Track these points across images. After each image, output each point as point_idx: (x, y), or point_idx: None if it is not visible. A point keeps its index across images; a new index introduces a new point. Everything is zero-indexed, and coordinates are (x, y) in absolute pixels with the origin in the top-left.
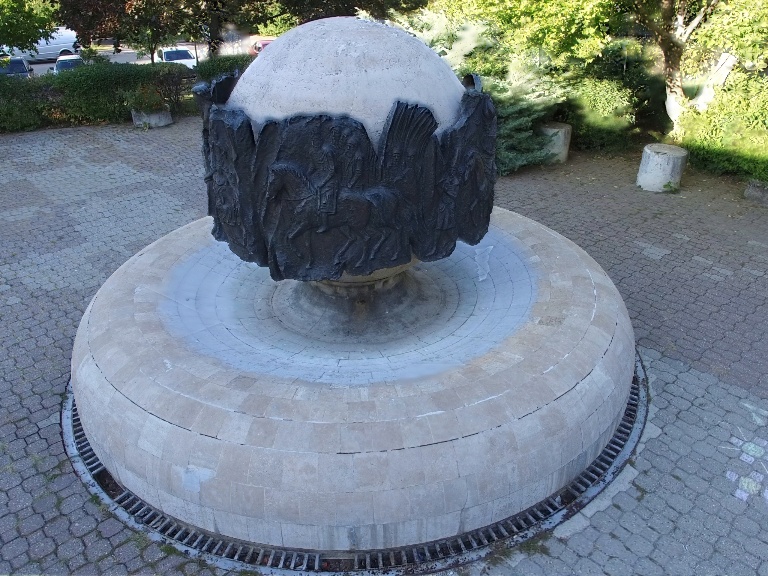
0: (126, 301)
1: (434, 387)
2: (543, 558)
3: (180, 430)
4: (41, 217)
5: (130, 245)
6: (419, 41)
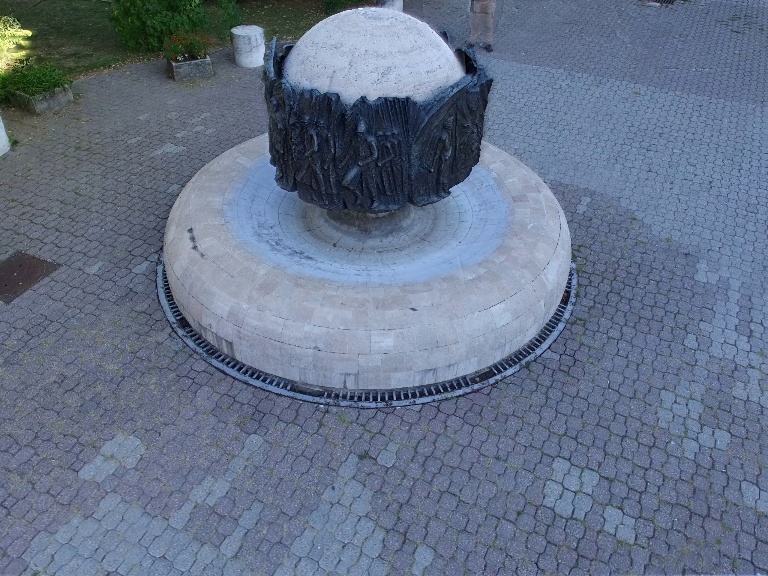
0: (489, 275)
1: None
2: None
3: (560, 213)
4: None
5: (218, 536)
6: None
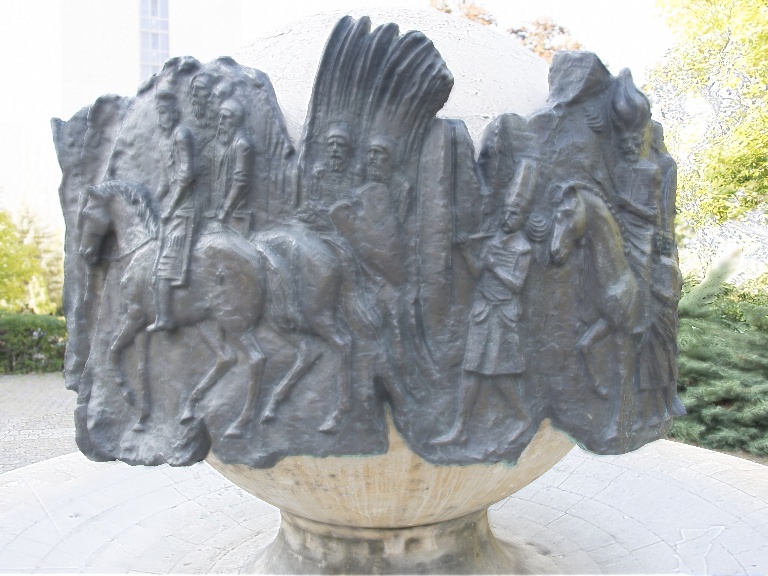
0: None
1: None
2: None
3: None
4: None
5: None
6: None
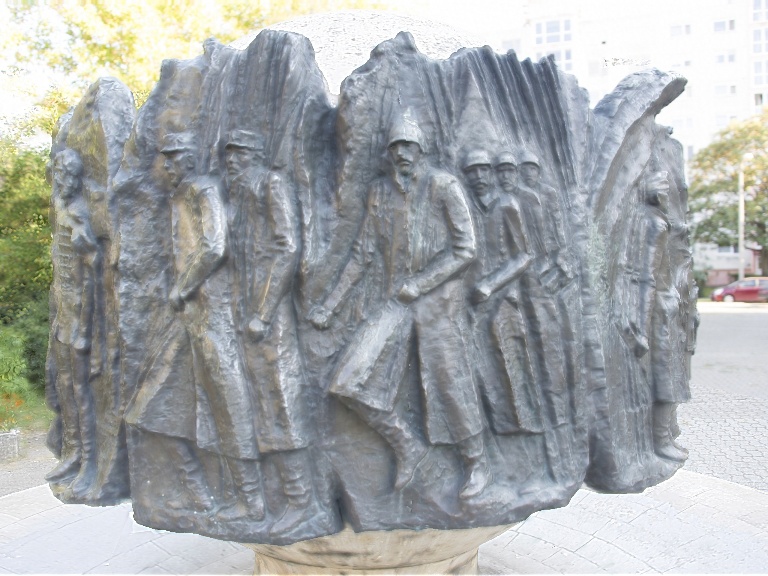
0: None
1: None
2: None
3: None
4: None
5: None
6: None
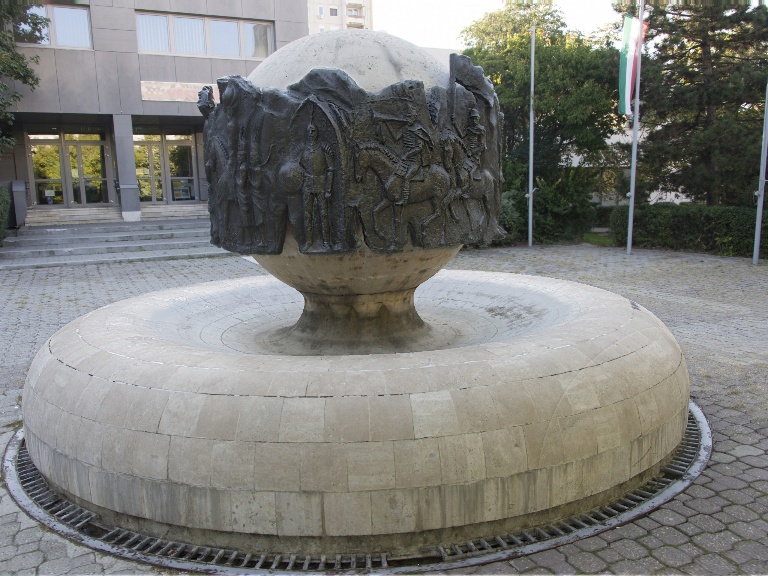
0: None
1: (130, 307)
2: (6, 424)
3: None
4: (722, 313)
5: None
6: (322, 38)
